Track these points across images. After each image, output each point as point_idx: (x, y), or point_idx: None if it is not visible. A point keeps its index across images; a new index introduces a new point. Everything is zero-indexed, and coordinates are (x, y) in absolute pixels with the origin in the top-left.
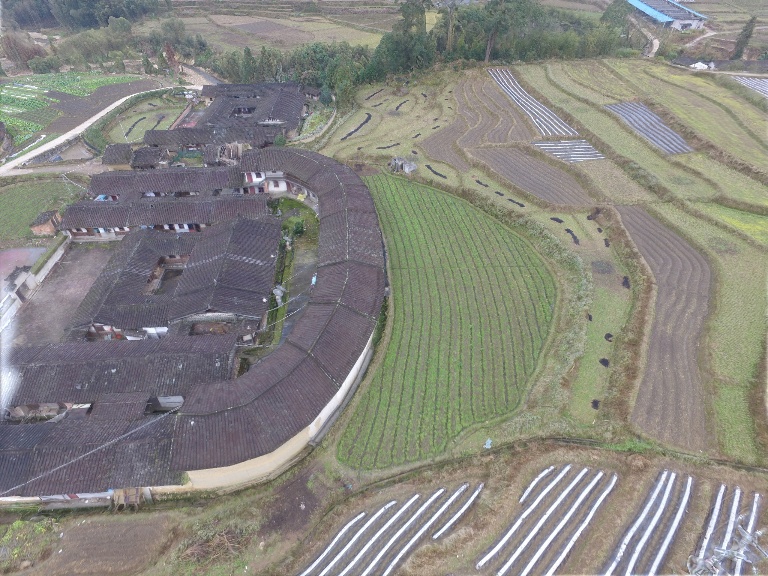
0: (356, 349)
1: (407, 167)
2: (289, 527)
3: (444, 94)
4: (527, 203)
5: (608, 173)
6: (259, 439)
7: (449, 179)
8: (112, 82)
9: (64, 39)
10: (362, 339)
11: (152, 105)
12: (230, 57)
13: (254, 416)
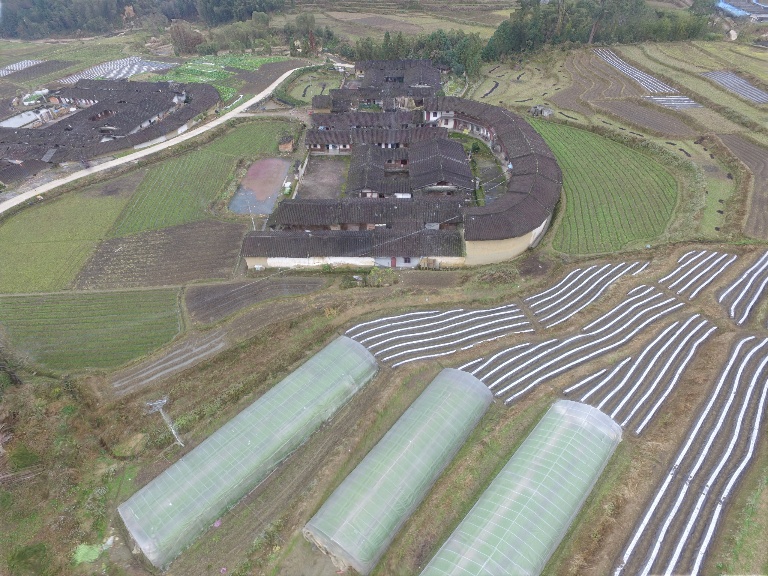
0: (555, 196)
1: (546, 111)
2: (536, 274)
3: (557, 68)
4: (645, 134)
5: (708, 115)
6: (513, 229)
7: (580, 120)
8: (271, 61)
9: (204, 32)
10: (556, 192)
11: (312, 77)
12: (365, 42)
13: (508, 218)
